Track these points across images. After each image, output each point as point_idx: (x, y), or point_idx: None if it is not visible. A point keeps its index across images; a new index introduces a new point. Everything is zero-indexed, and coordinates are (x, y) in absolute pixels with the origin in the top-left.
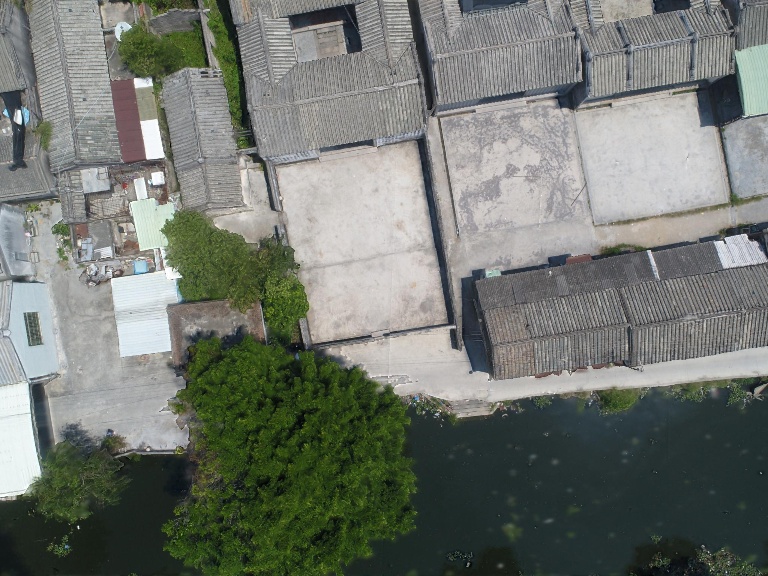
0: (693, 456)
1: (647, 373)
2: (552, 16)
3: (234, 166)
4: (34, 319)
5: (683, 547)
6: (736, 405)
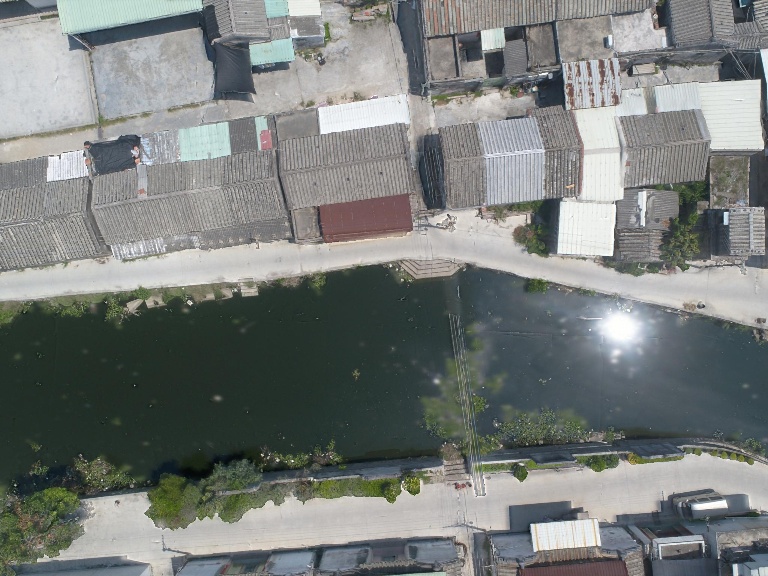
0: (76, 369)
1: (15, 287)
2: None
3: None
4: None
5: (61, 456)
6: (114, 320)
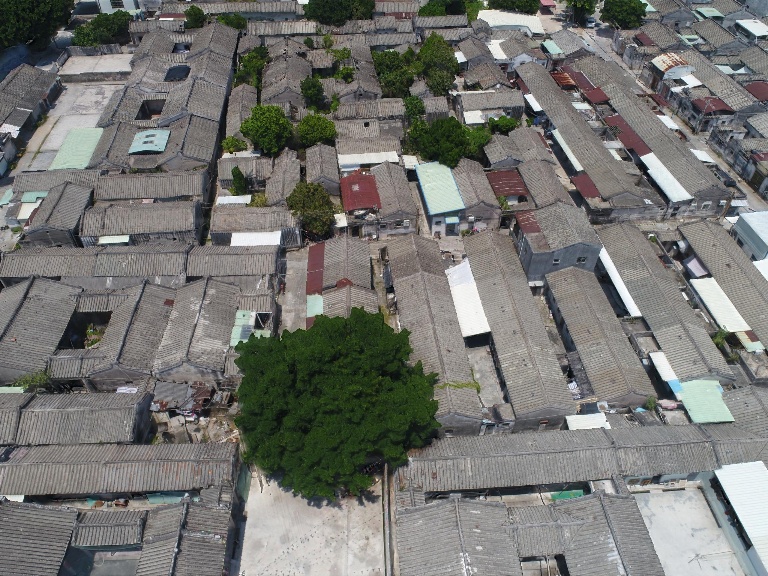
0: None
1: None
2: (152, 82)
3: (144, 31)
4: (121, 5)
5: None
6: None
